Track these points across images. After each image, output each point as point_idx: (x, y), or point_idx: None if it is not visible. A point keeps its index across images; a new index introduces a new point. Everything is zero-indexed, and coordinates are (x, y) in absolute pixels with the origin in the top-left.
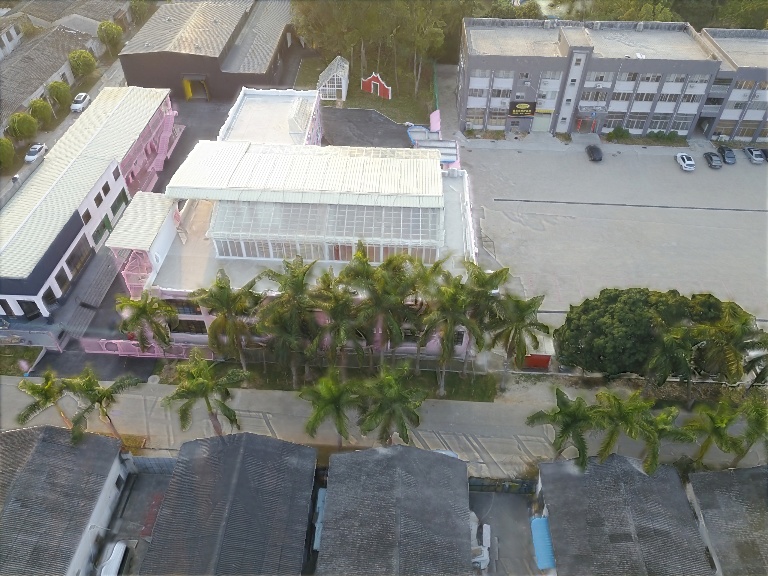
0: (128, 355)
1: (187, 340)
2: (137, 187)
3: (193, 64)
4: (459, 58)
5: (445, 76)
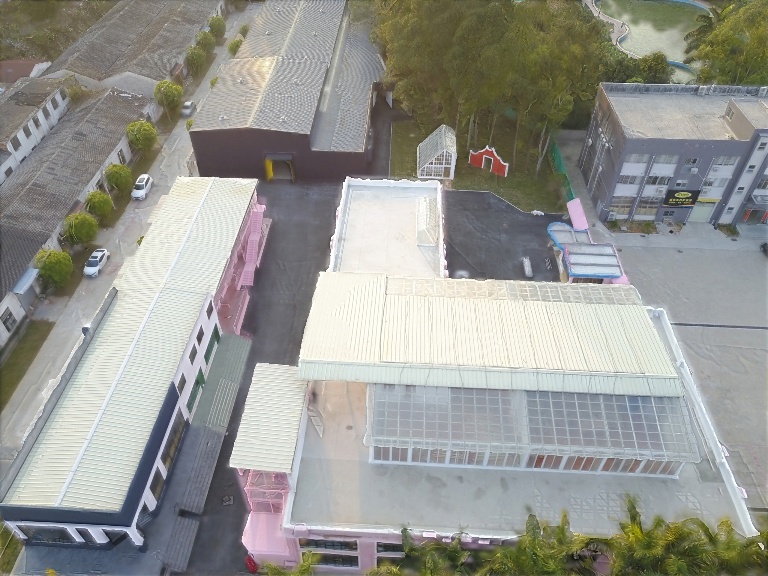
0: None
1: (329, 574)
2: (227, 314)
3: (278, 141)
4: (591, 129)
5: (561, 143)
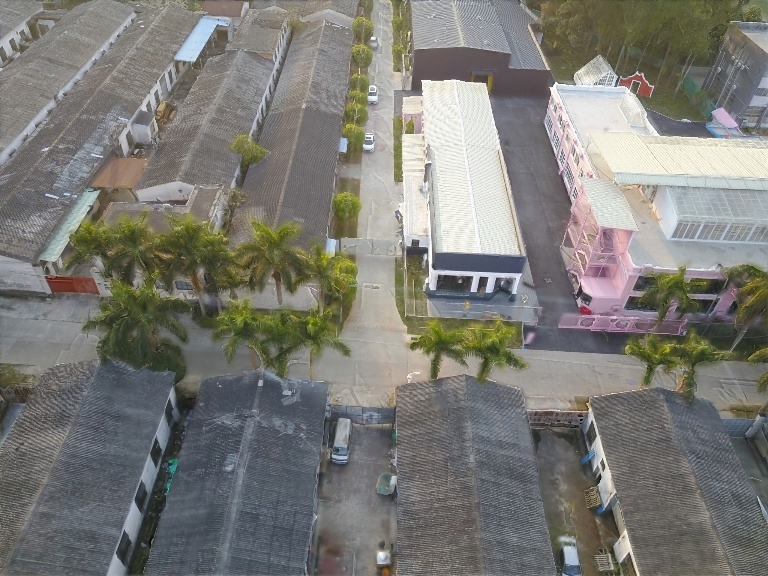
0: (604, 330)
1: None
2: None
3: (484, 60)
4: (720, 59)
5: None
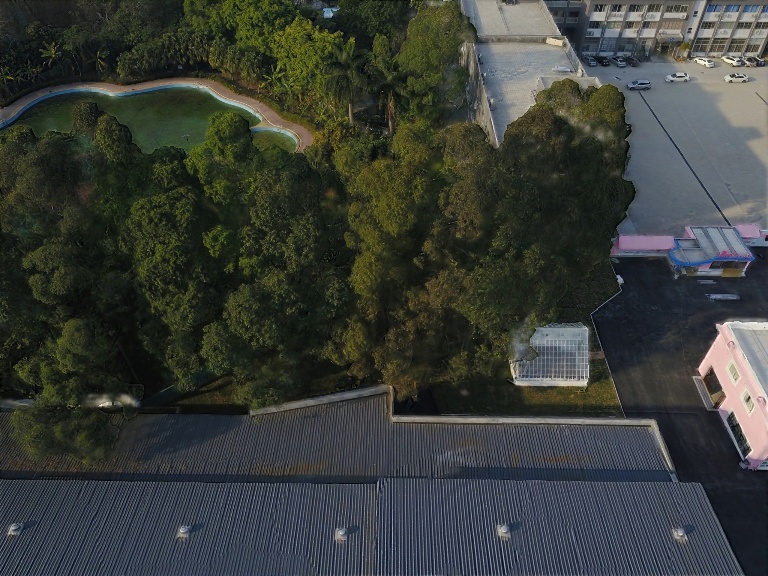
0: None
1: None
2: None
3: None
4: None
5: None
